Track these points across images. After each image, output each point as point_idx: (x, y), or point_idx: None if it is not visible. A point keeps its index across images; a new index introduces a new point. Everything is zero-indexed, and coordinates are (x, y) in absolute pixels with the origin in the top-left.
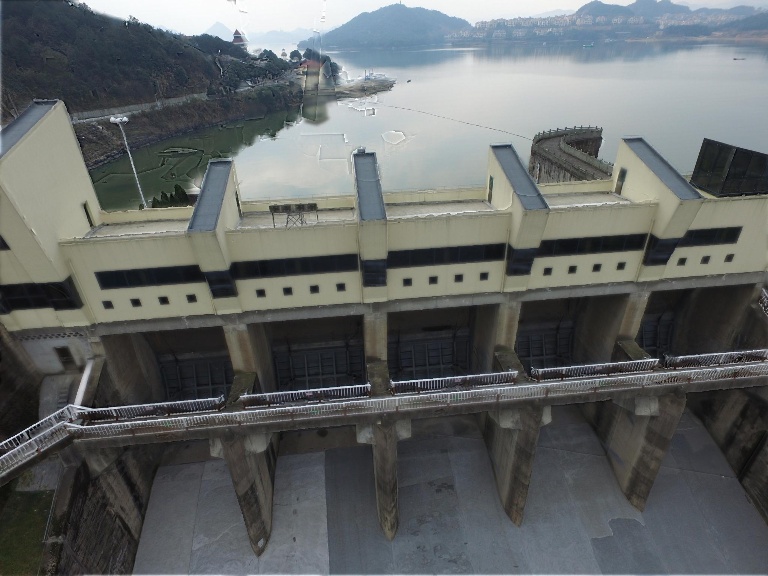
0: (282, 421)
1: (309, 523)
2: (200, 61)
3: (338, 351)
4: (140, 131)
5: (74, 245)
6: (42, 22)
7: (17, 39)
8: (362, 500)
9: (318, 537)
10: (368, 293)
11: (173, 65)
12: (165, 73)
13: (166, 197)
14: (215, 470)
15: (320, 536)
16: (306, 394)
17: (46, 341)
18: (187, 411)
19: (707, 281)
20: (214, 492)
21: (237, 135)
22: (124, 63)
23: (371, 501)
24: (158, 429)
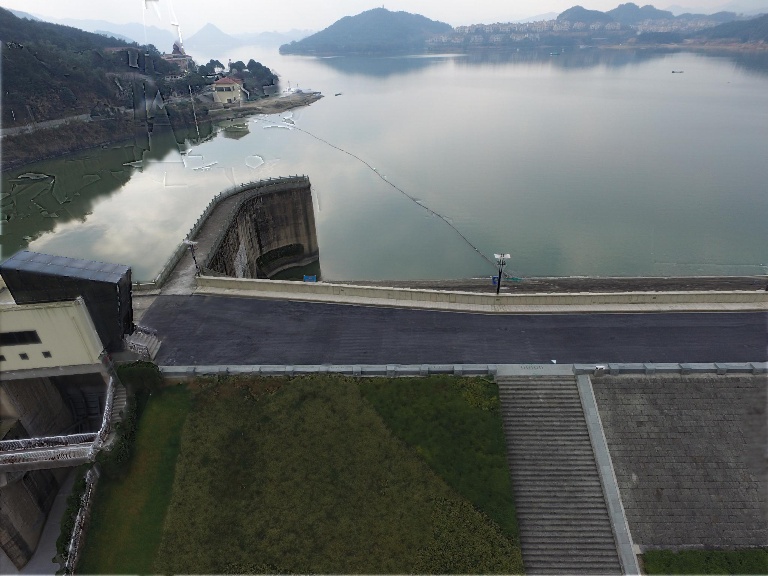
0: None
1: None
2: (91, 82)
3: None
4: (1, 156)
5: None
6: None
7: None
8: None
9: None
10: None
11: (59, 87)
12: (49, 95)
13: None
14: None
15: None
16: None
17: None
18: None
19: (47, 372)
20: None
21: (127, 154)
22: None
23: None
24: None
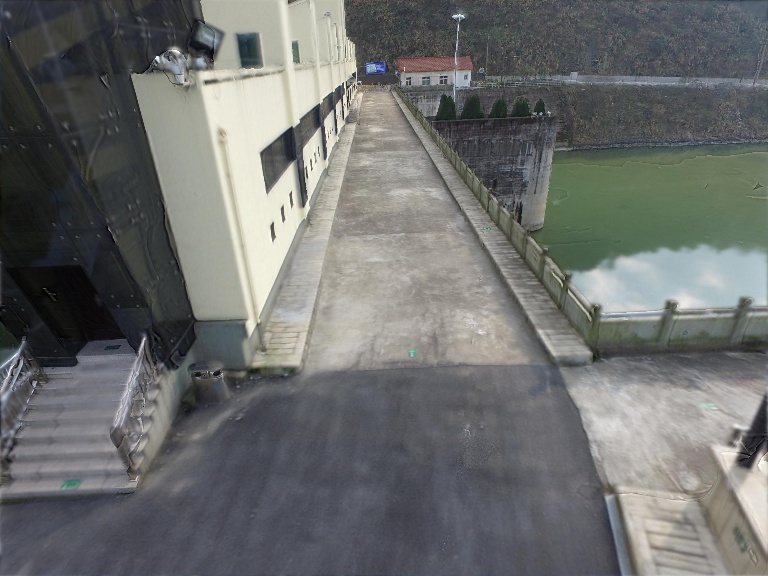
0: None
1: None
2: None
3: None
4: None
5: None
6: None
7: None
8: None
9: None
10: None
11: None
12: None
13: (518, 105)
14: None
15: None
16: None
17: None
18: None
19: None
20: None
21: None
22: None
23: None
24: None
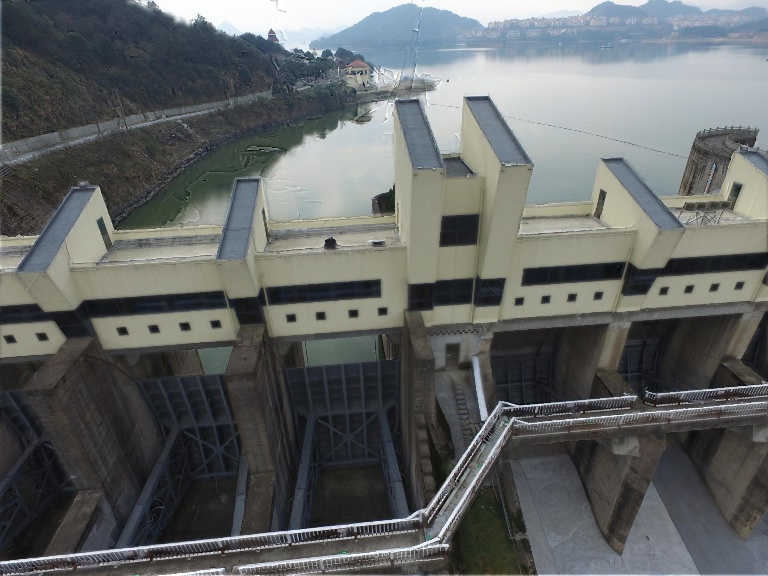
0: (708, 419)
1: (655, 522)
2: (261, 60)
3: (633, 350)
4: (218, 129)
5: (519, 241)
6: (121, 20)
7: (101, 37)
8: (697, 499)
9: (671, 536)
10: (766, 291)
11: (238, 64)
12: (231, 72)
13: None
14: (534, 468)
15: (672, 535)
16: (718, 392)
17: (443, 337)
18: (602, 409)
19: None
20: (545, 490)
21: (298, 134)
22: (197, 61)
23: (707, 500)
24: (593, 426)
